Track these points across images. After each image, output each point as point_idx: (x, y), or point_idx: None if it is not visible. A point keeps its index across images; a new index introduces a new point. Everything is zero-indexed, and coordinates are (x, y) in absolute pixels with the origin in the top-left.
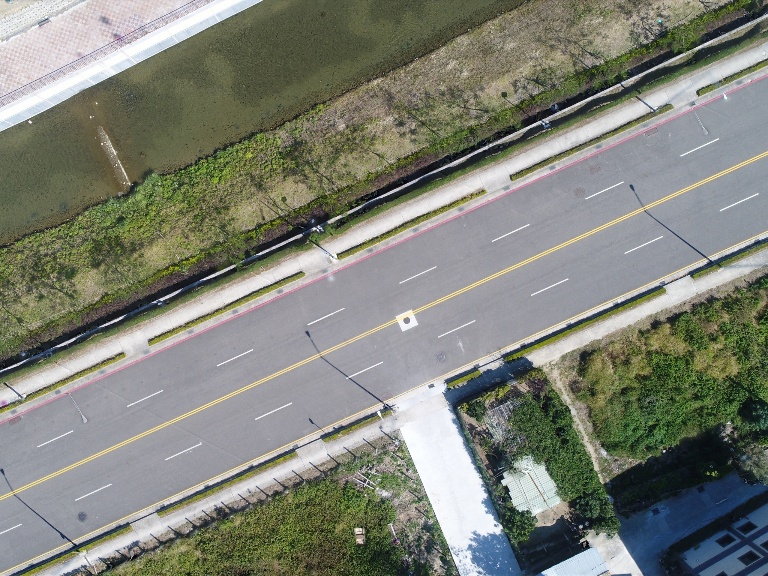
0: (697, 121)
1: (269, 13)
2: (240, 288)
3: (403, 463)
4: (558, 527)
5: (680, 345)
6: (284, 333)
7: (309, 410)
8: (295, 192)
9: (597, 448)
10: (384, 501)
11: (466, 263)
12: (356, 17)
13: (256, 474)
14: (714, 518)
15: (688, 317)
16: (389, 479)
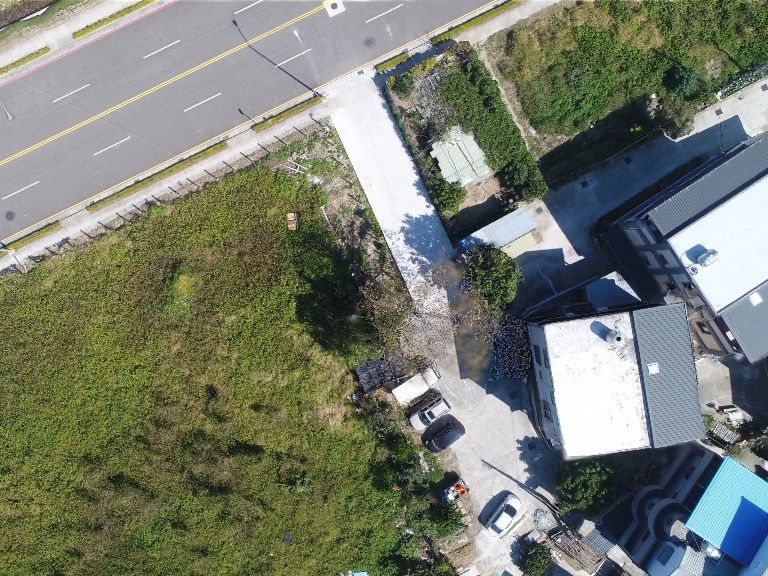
0: None
1: None
2: None
3: (334, 149)
4: (489, 206)
5: (604, 18)
6: (211, 23)
7: (238, 100)
8: None
9: (526, 127)
10: (315, 186)
11: None
12: None
13: (186, 166)
14: (641, 188)
15: None
16: (320, 165)
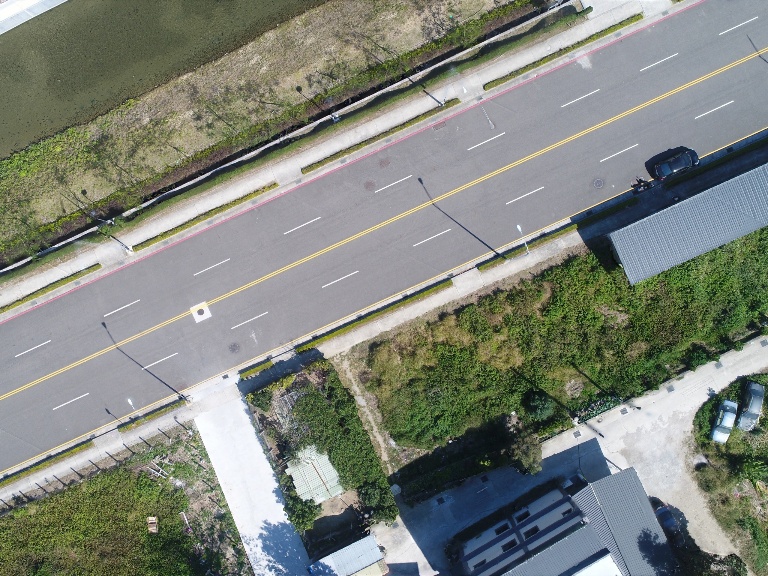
0: (484, 115)
1: (83, 8)
2: (38, 280)
3: (197, 453)
4: (347, 516)
5: (465, 336)
6: (81, 324)
7: (106, 400)
8: (94, 185)
9: (386, 438)
10: (176, 490)
11: (259, 255)
12: (168, 12)
13: (53, 463)
14: (497, 507)
15: (473, 309)
16: (182, 468)
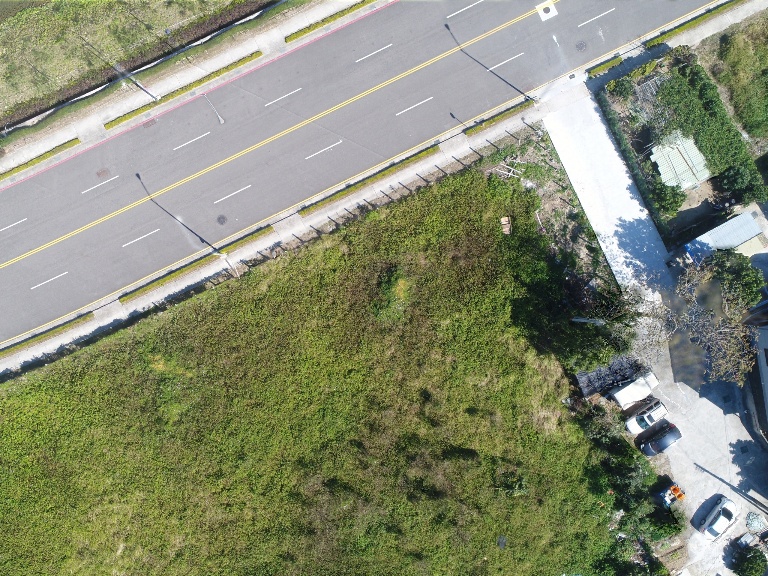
0: None
1: None
2: None
3: (546, 153)
4: (703, 210)
5: None
6: (423, 27)
7: (450, 104)
8: None
9: (739, 131)
10: (530, 190)
11: None
12: None
13: (398, 170)
14: None
15: None
16: (533, 169)
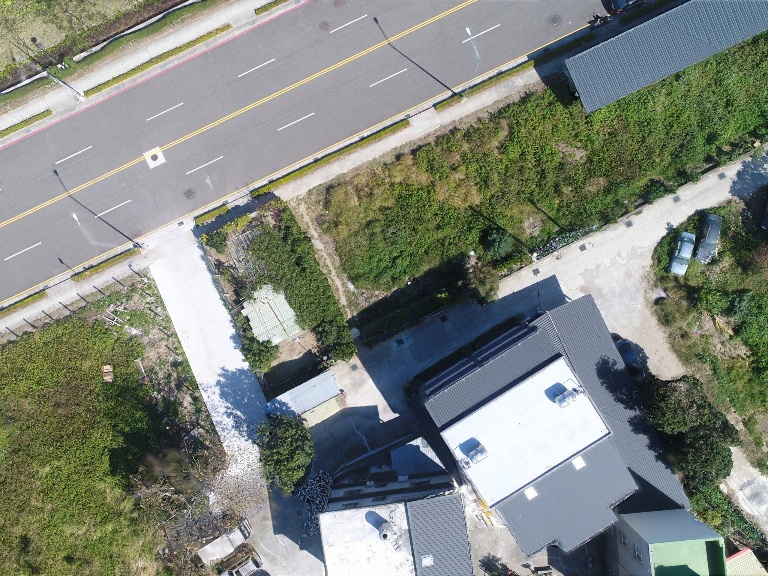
0: None
1: None
2: None
3: (152, 301)
4: (305, 361)
5: (422, 175)
6: (32, 172)
7: (58, 250)
8: (44, 32)
9: (344, 282)
10: (132, 338)
11: (213, 99)
12: None
13: (6, 315)
14: (457, 347)
15: (430, 147)
16: (138, 317)
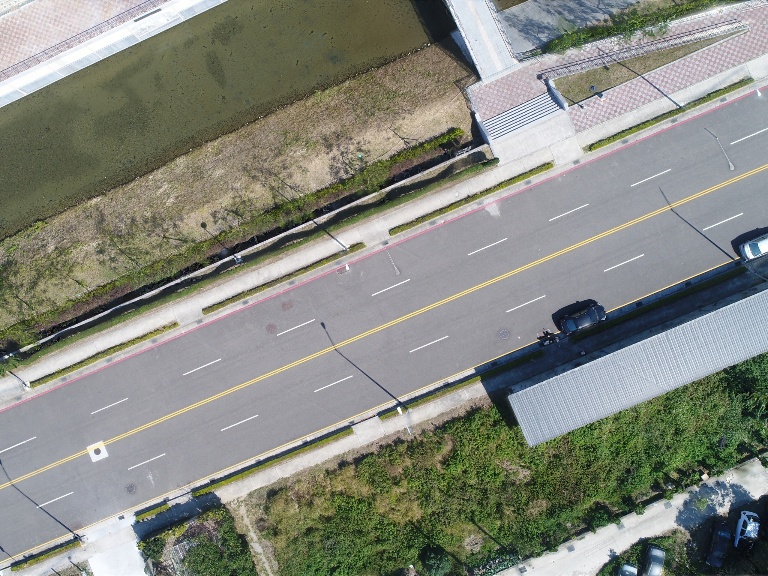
0: (389, 261)
1: None
2: None
3: None
4: None
5: (363, 488)
6: None
7: None
8: None
9: None
10: None
11: (157, 396)
12: (80, 133)
13: None
14: None
15: (372, 459)
16: None
